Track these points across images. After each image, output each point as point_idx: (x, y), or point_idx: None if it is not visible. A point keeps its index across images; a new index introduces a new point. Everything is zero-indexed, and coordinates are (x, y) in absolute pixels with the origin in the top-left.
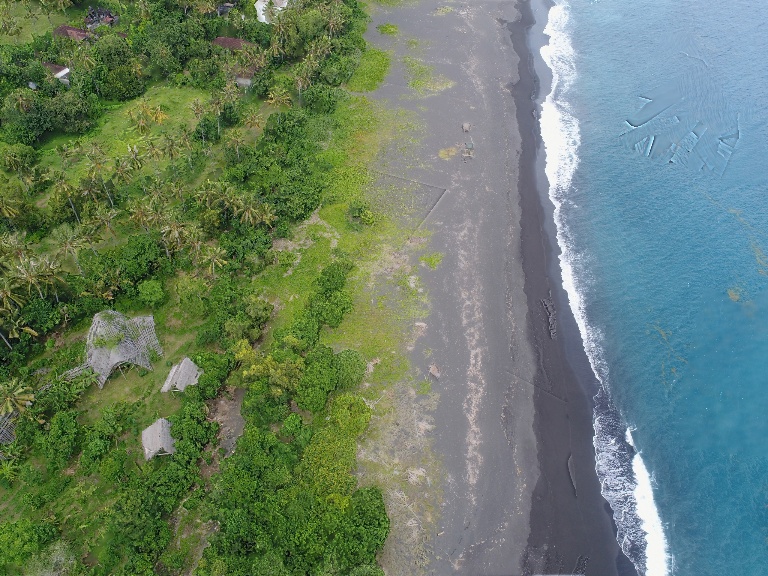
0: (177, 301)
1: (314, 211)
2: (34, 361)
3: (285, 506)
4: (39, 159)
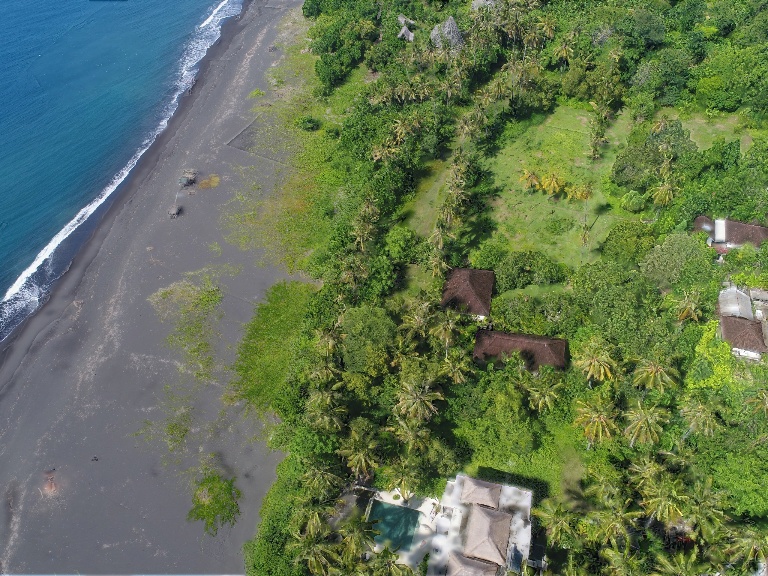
0: (430, 74)
1: None
2: None
3: None
4: None
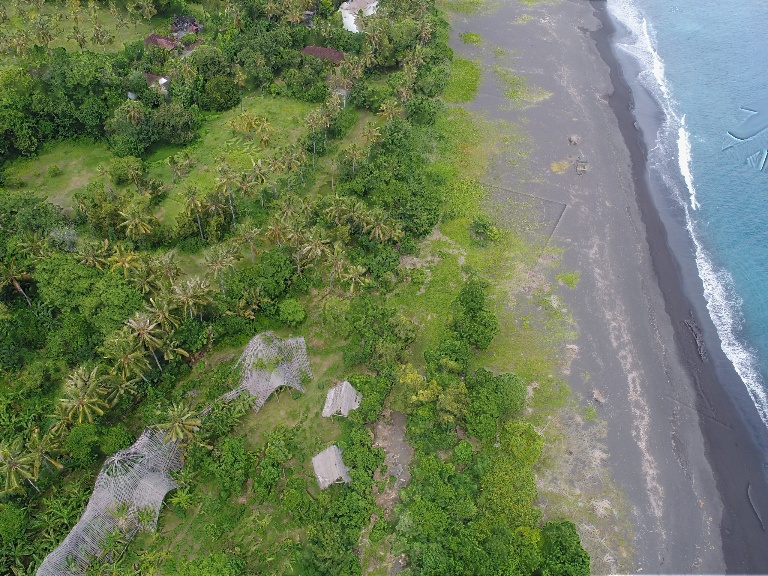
0: (315, 320)
1: (434, 226)
2: (184, 382)
3: (483, 541)
4: (147, 171)
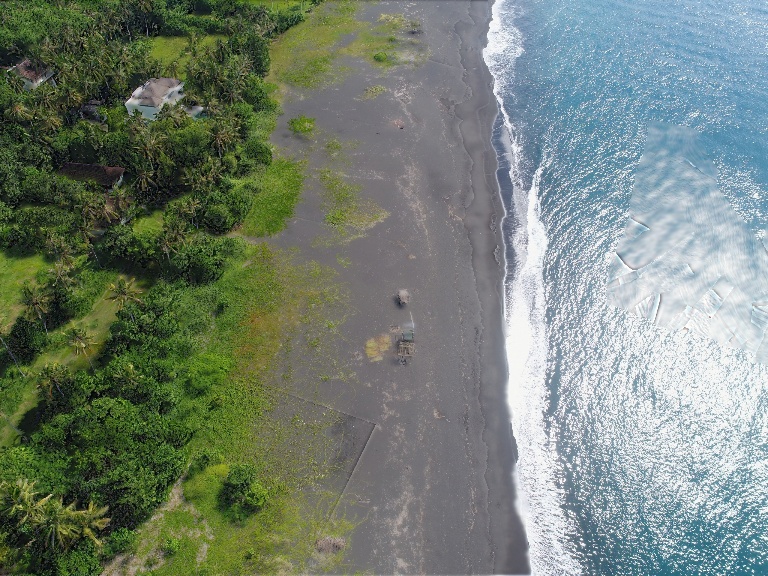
0: None
1: (177, 480)
2: None
3: None
4: None
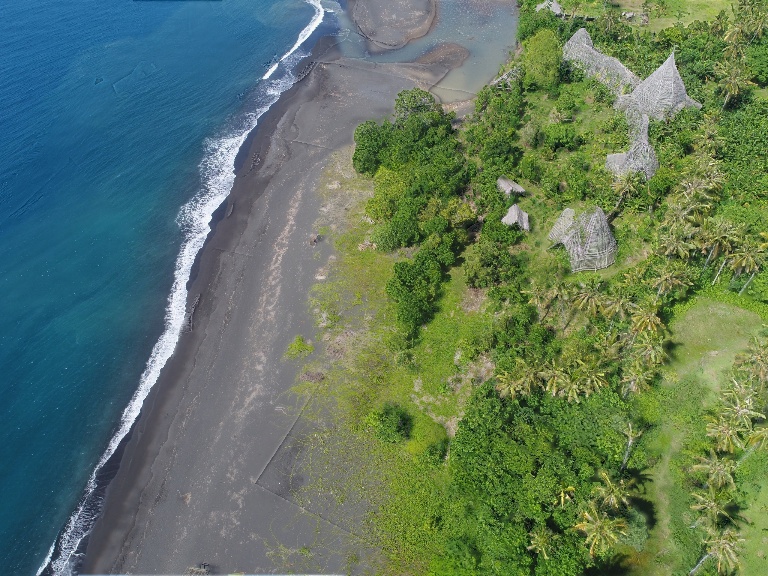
0: None
1: None
2: None
3: None
4: None
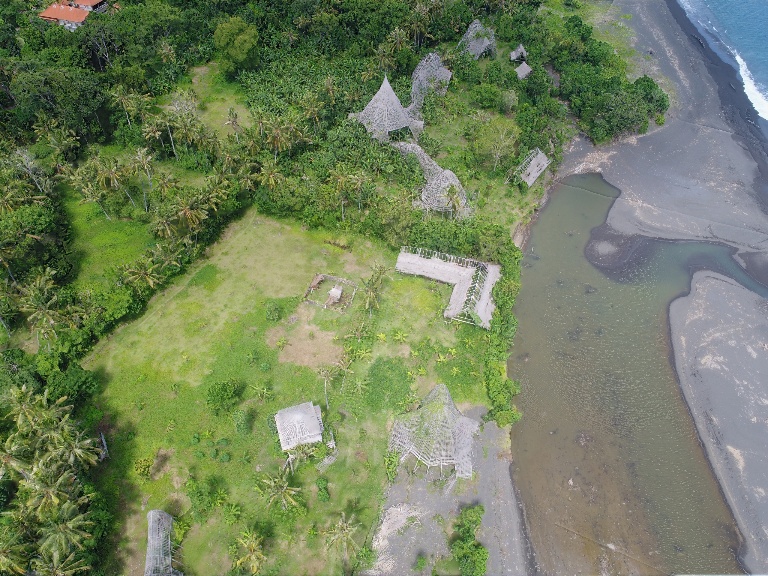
0: None
1: (541, 5)
2: None
3: None
4: None
